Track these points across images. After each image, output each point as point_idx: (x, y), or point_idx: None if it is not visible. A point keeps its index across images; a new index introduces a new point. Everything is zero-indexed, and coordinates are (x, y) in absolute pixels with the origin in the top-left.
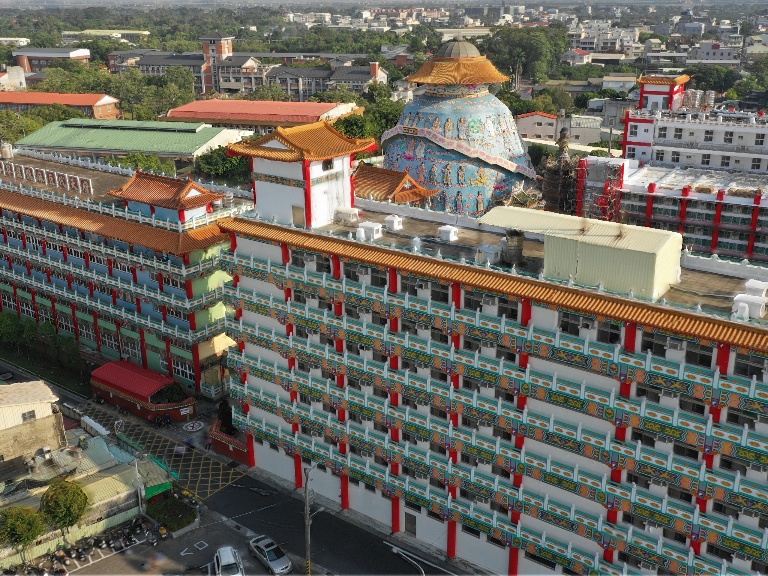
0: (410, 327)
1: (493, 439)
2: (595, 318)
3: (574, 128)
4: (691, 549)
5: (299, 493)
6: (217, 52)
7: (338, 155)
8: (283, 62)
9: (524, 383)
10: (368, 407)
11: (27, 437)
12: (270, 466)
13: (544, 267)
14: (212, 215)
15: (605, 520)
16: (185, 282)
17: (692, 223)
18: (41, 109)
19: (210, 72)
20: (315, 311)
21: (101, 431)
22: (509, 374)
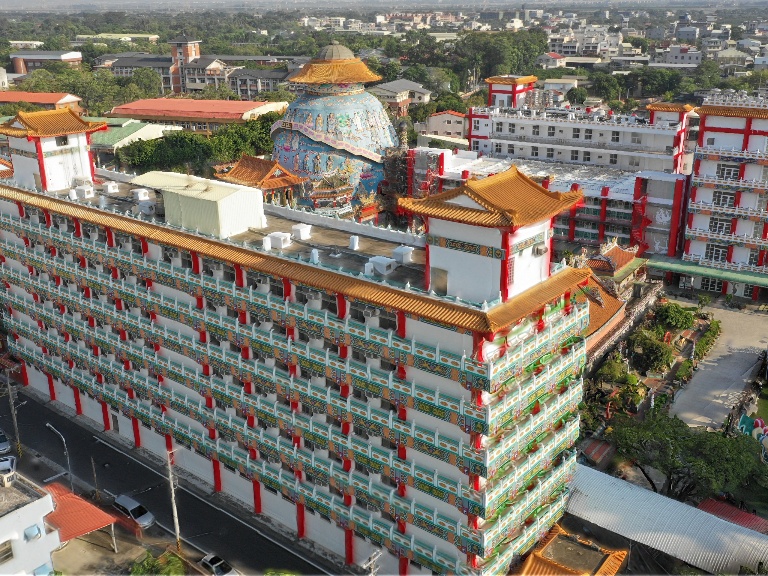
0: (92, 264)
1: (141, 348)
2: (177, 249)
3: None
4: (245, 422)
5: (51, 404)
6: (184, 55)
7: (65, 134)
8: (258, 64)
9: (148, 302)
10: (76, 329)
11: None
12: (37, 384)
13: (165, 215)
14: None
15: (203, 405)
16: None
17: None
18: (8, 106)
19: (178, 73)
20: (40, 254)
21: None
22: (140, 295)
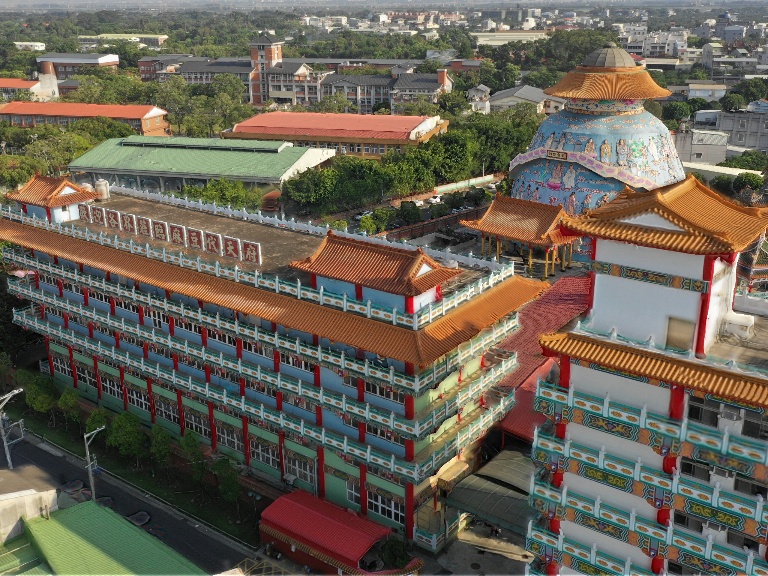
0: None
1: None
2: None
3: (696, 145)
4: None
5: None
6: (266, 58)
7: None
8: (327, 68)
9: None
10: None
11: None
12: None
13: None
14: (449, 300)
15: None
16: (404, 393)
17: None
18: (84, 122)
19: (258, 80)
20: (734, 498)
21: None
22: None
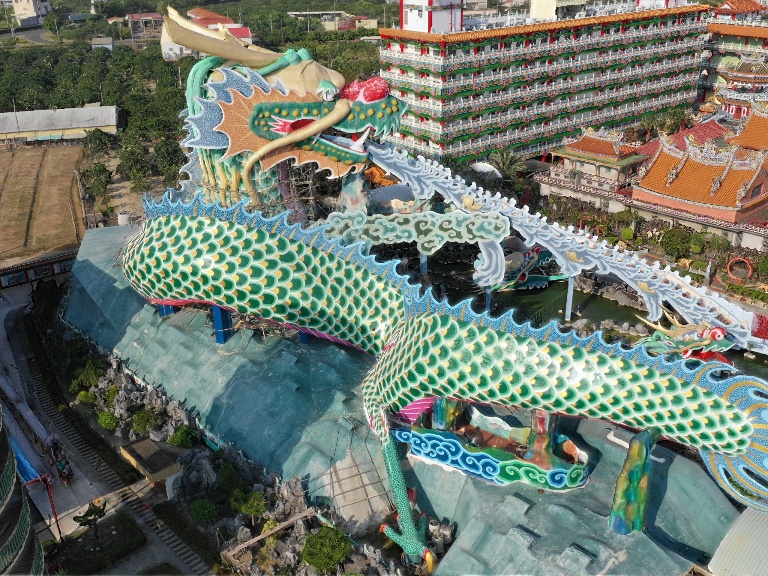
0: None
1: None
2: None
3: None
4: None
5: None
6: None
7: None
8: None
9: None
10: None
11: None
12: None
13: None
14: (724, 20)
15: None
16: None
17: None
18: None
19: None
20: None
21: None
22: None
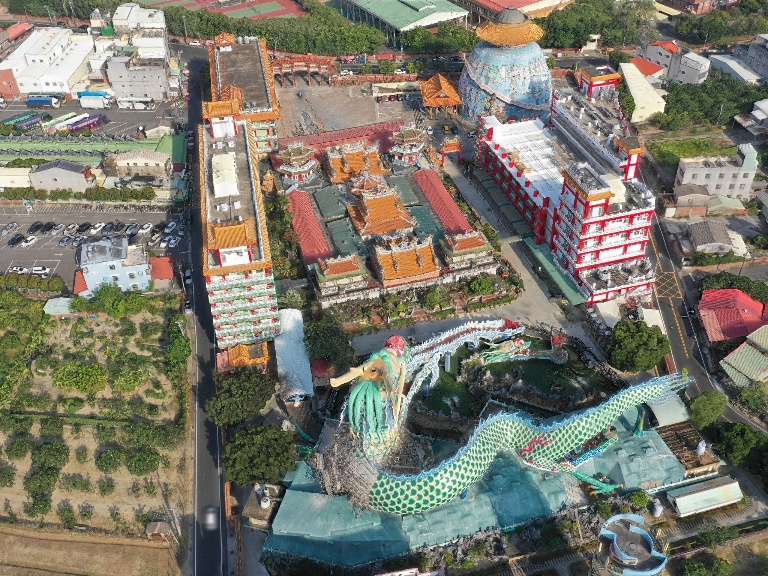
0: None
1: None
2: None
3: (683, 65)
4: None
5: None
6: None
7: None
8: None
9: None
10: None
11: (157, 171)
12: None
13: None
14: None
15: None
16: None
17: (501, 174)
18: None
19: None
20: None
21: (182, 176)
22: None
